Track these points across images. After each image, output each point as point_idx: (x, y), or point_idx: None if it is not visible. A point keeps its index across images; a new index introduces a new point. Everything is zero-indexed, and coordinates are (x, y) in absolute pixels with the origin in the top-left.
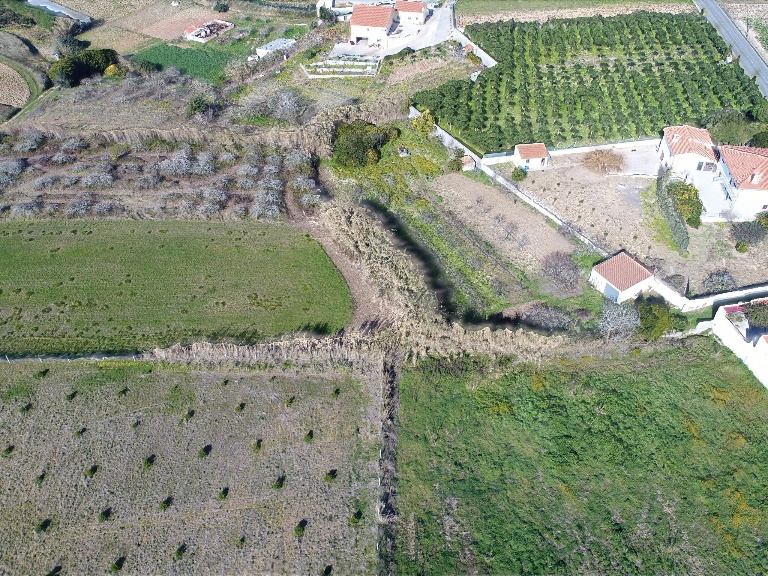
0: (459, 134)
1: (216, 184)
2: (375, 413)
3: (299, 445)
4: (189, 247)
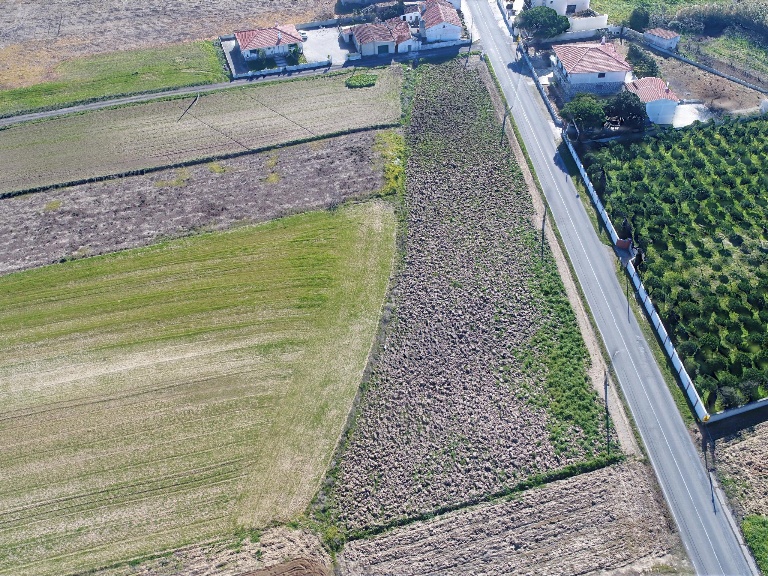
0: None
1: None
2: None
3: None
4: None
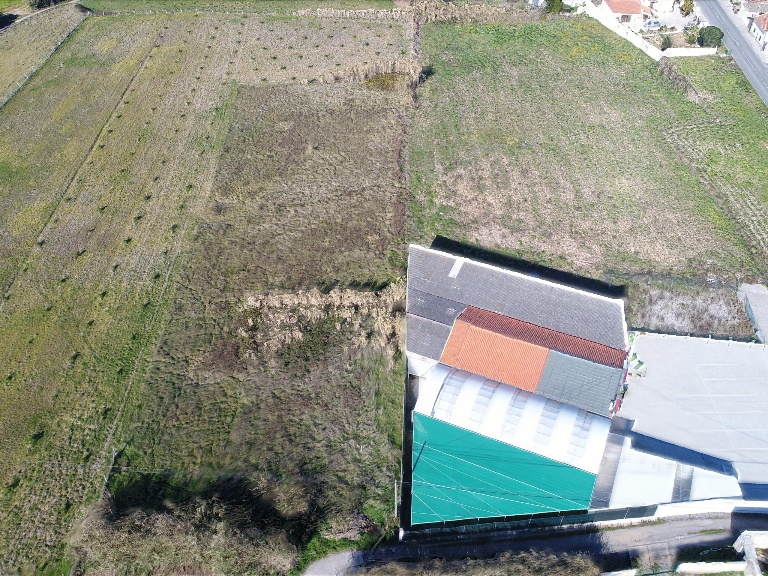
0: None
1: None
2: None
3: None
4: None
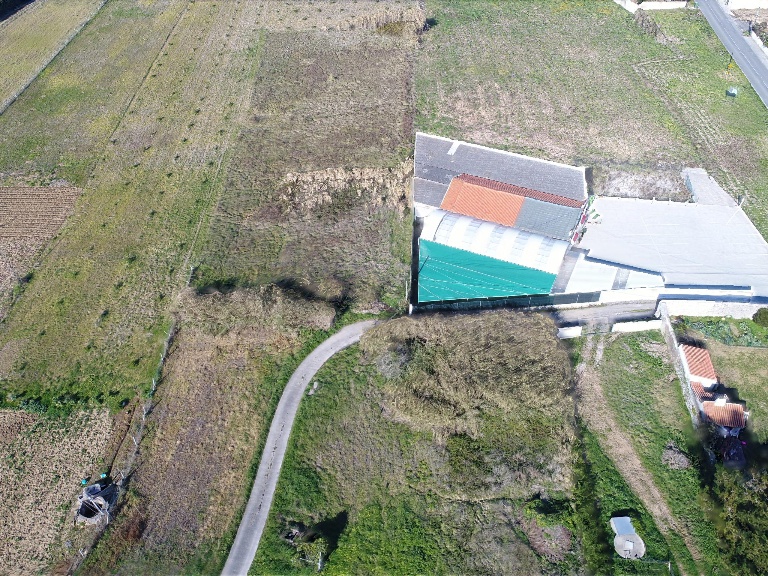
0: None
1: None
2: None
3: None
4: None
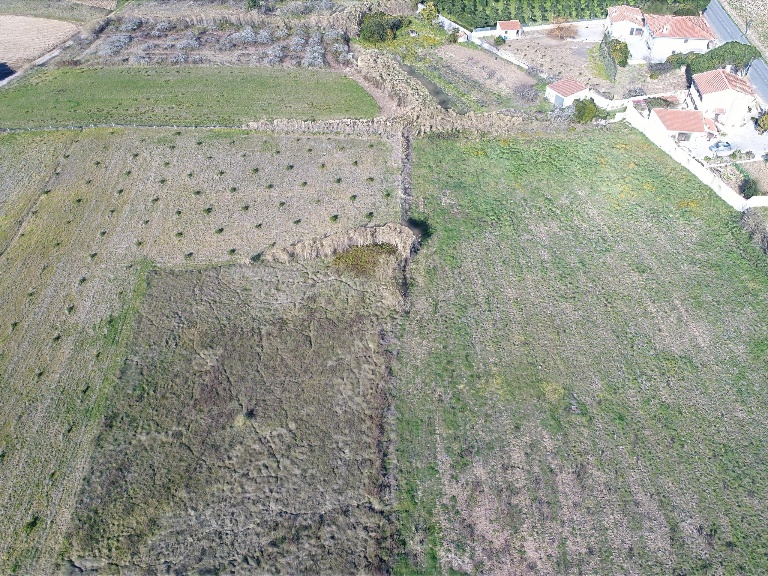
0: (456, 18)
1: (275, 48)
2: (397, 156)
3: (349, 167)
4: (261, 80)
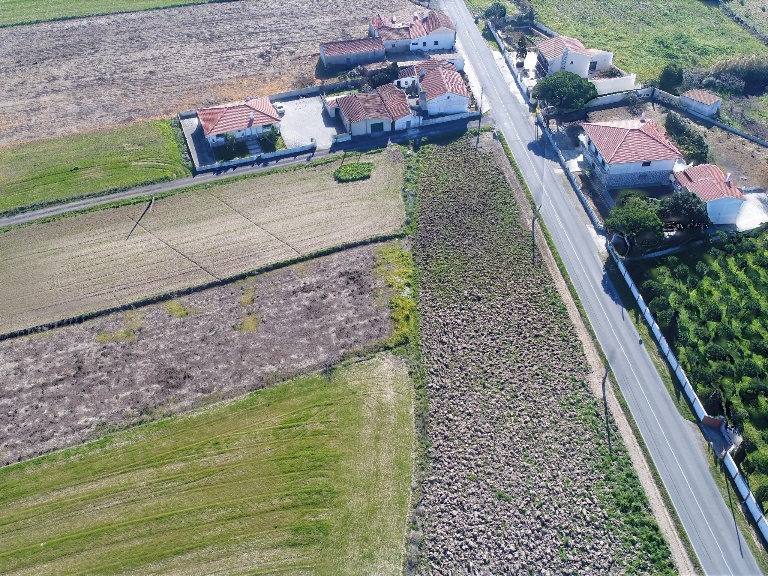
0: None
1: None
2: None
3: None
4: None
